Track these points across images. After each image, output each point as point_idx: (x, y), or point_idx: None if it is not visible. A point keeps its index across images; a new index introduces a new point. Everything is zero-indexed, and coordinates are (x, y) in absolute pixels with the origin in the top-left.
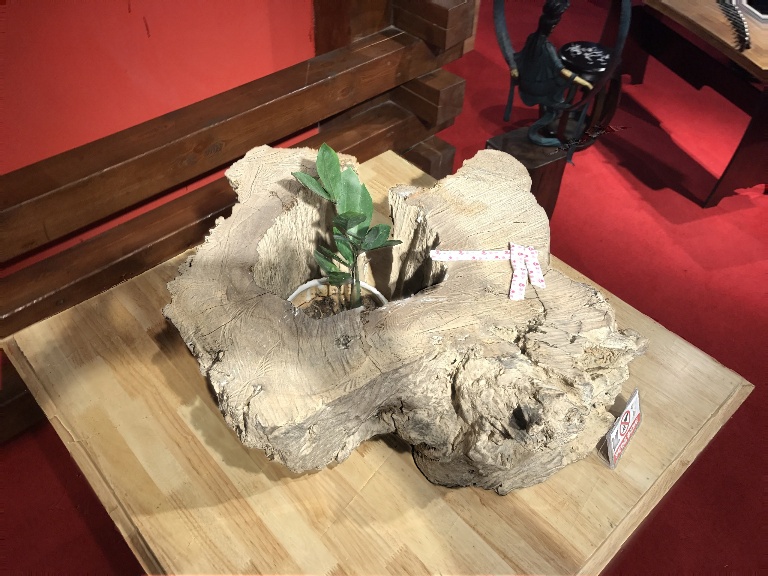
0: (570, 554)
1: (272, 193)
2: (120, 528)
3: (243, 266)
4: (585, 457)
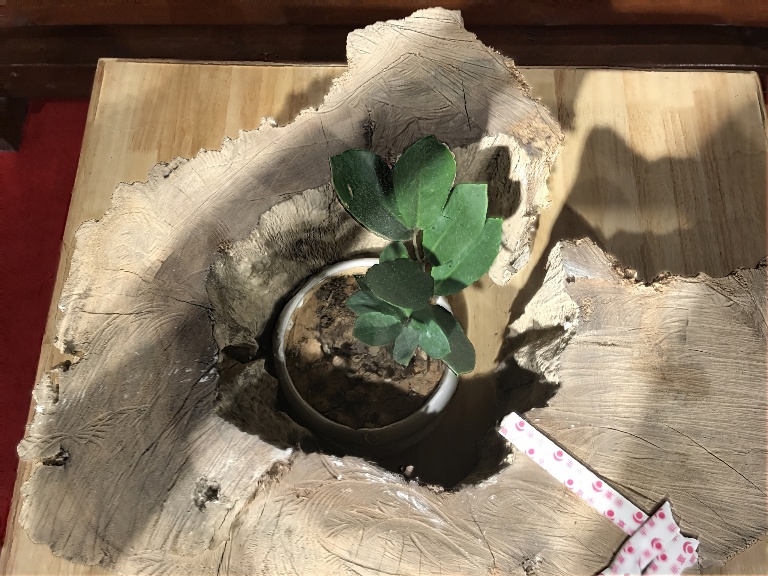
0: None
1: (370, 124)
2: (39, 368)
3: (218, 233)
4: None
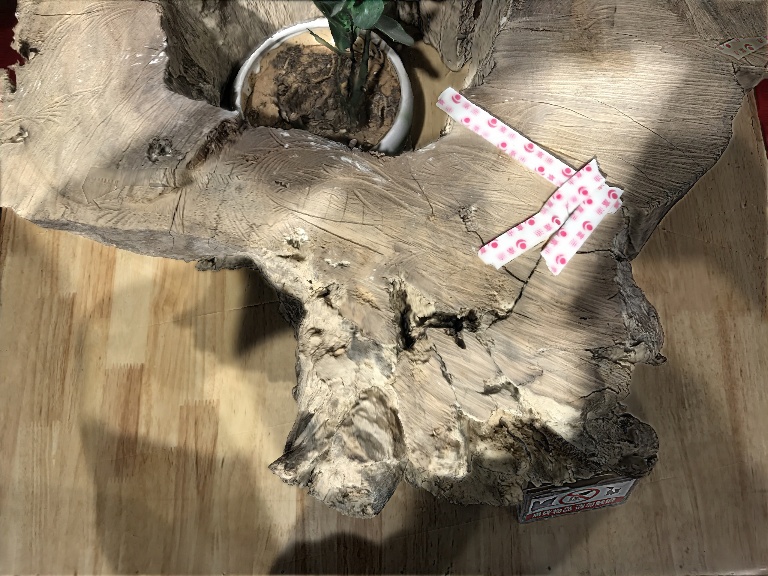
0: (369, 559)
1: None
2: None
3: None
4: (451, 502)
